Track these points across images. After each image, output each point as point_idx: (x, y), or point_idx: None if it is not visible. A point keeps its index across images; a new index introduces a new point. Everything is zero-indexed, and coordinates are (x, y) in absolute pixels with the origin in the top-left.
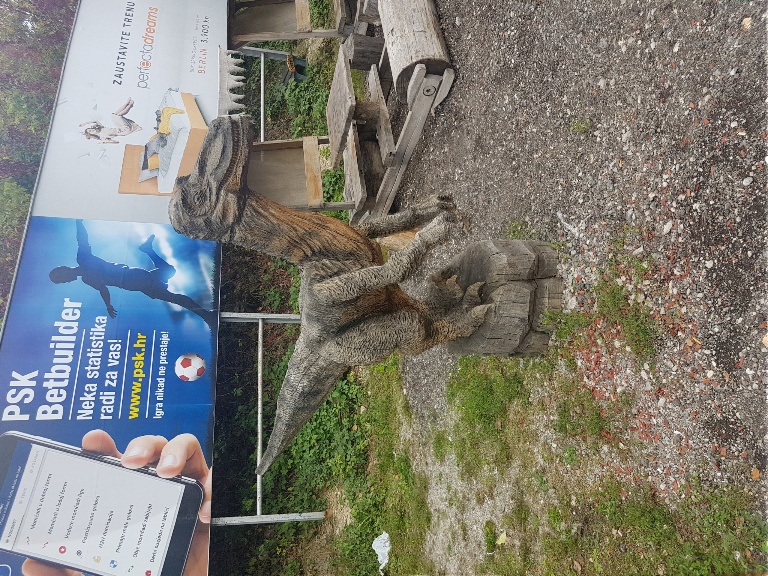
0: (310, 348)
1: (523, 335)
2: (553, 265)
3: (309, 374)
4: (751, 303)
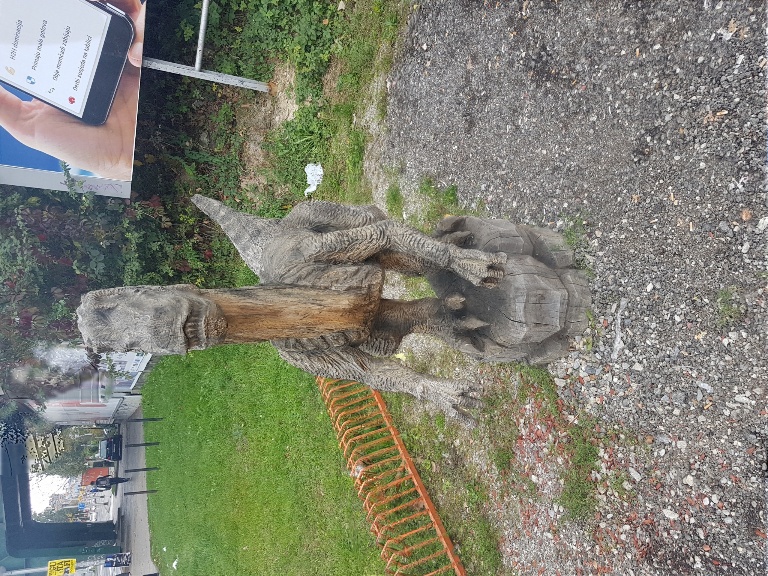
0: None
1: None
2: (573, 335)
3: None
4: None
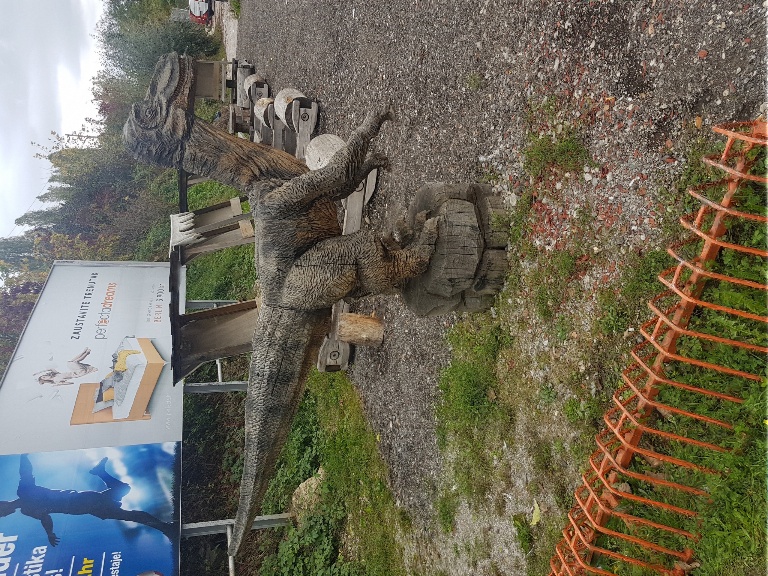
0: (271, 304)
1: (480, 249)
2: (488, 189)
3: (274, 343)
4: (629, 25)
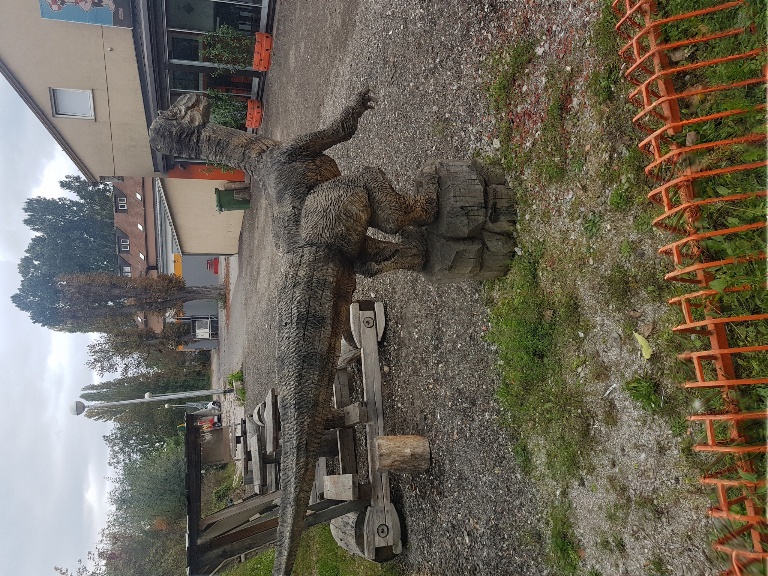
0: (291, 248)
1: None
2: None
3: (299, 283)
4: None
